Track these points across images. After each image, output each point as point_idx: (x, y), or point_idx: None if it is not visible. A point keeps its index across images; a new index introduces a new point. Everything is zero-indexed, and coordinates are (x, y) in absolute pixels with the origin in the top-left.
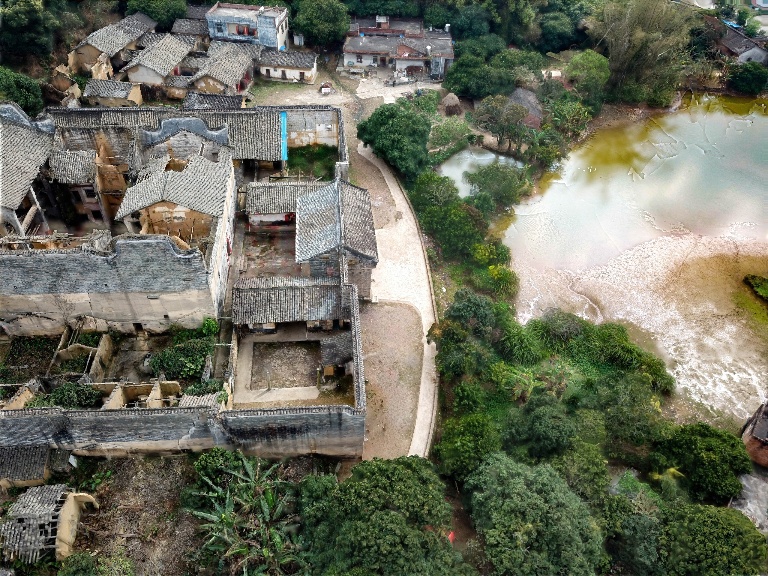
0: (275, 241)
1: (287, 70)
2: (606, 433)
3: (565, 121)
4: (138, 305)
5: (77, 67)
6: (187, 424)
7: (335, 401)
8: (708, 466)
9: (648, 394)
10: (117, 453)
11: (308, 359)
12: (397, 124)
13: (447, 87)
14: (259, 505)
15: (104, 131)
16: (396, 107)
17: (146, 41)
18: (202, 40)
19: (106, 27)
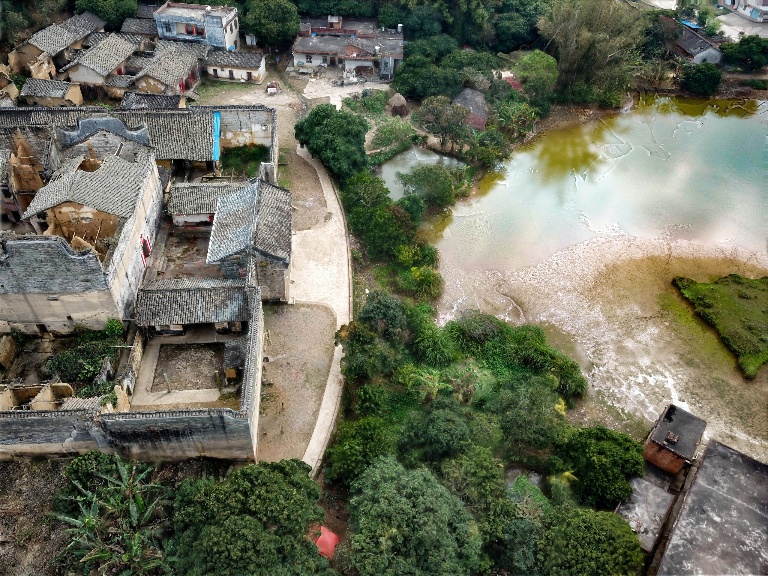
0: (198, 242)
1: (234, 70)
2: (506, 436)
3: (510, 122)
4: (38, 306)
5: (19, 66)
6: (67, 427)
7: (235, 404)
8: (599, 470)
9: (548, 397)
10: (2, 456)
11: (214, 361)
12: (331, 124)
13: (395, 87)
14: (127, 509)
15: (21, 131)
16: (331, 107)
17: (92, 40)
18: (151, 40)
19: (50, 26)
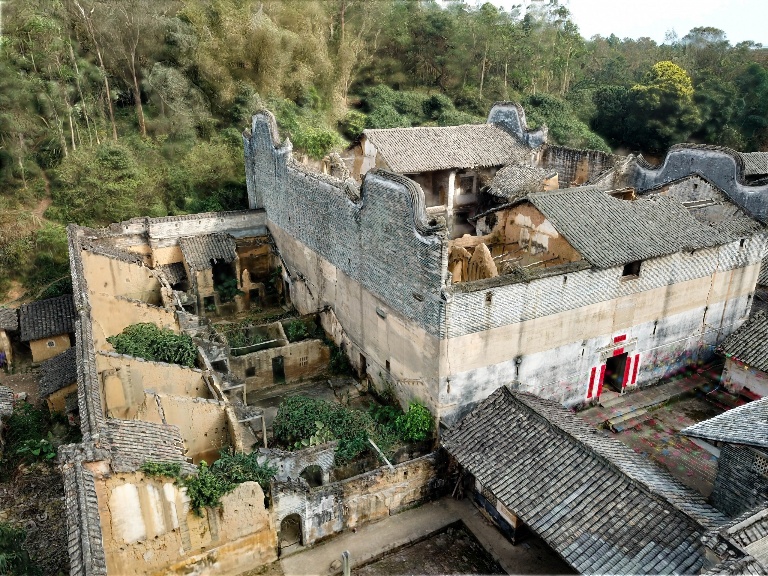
0: None
1: None
2: None
3: None
4: (368, 320)
5: None
6: None
7: None
8: None
9: None
10: None
11: None
12: None
13: None
14: None
15: (590, 158)
16: None
17: None
18: None
19: None
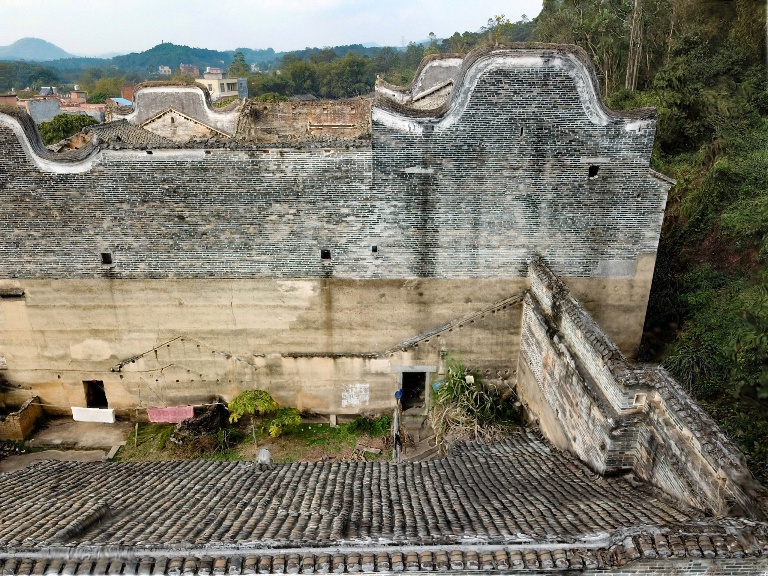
0: None
1: None
2: None
3: None
4: None
5: None
6: None
7: None
8: None
9: None
10: None
11: None
12: None
13: None
14: None
15: None
16: None
17: None
18: None
19: None
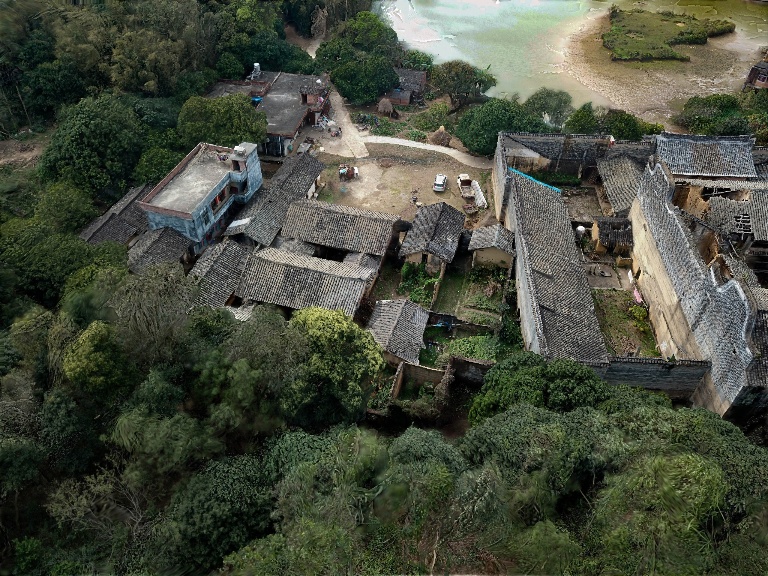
0: None
1: None
2: None
3: (432, 64)
4: None
5: None
6: None
7: None
8: None
9: None
10: None
11: None
12: None
13: (365, 101)
14: None
15: None
16: (497, 103)
17: None
18: None
19: None
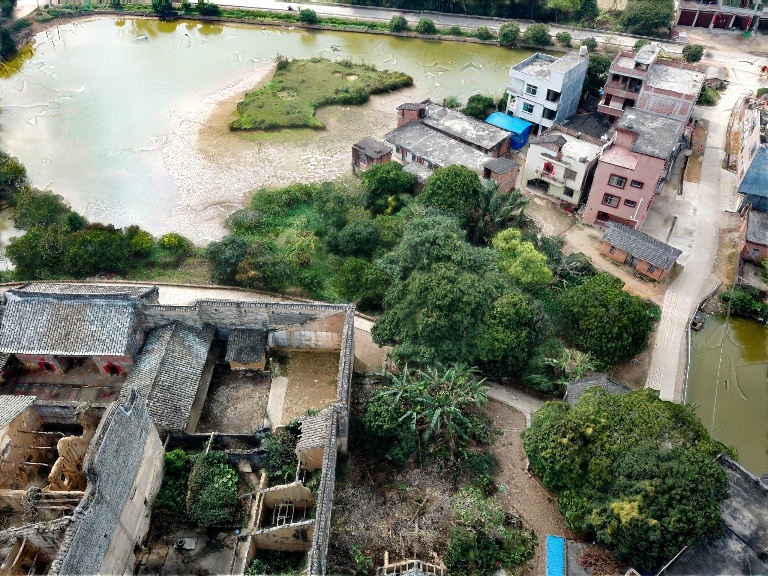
0: None
1: None
2: None
3: None
4: (128, 522)
5: None
6: None
7: (294, 365)
8: (398, 178)
9: None
10: None
11: (234, 385)
12: None
13: None
14: None
15: None
16: None
17: None
18: None
19: None
